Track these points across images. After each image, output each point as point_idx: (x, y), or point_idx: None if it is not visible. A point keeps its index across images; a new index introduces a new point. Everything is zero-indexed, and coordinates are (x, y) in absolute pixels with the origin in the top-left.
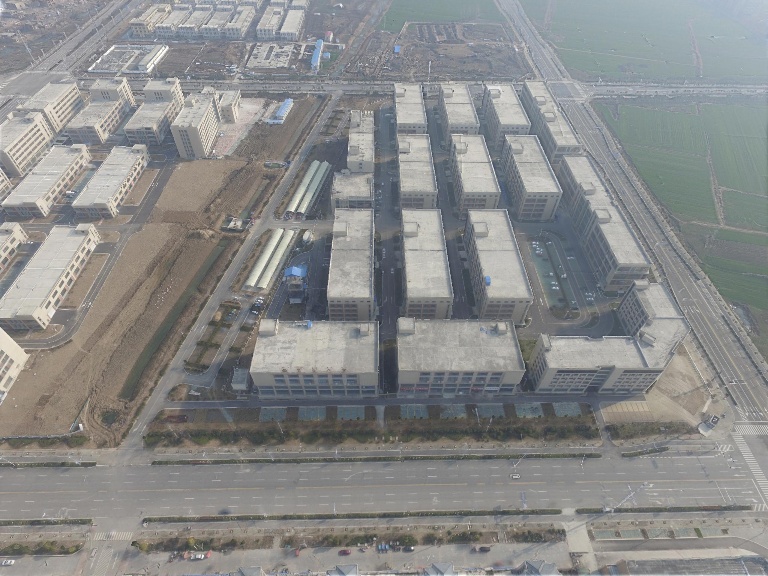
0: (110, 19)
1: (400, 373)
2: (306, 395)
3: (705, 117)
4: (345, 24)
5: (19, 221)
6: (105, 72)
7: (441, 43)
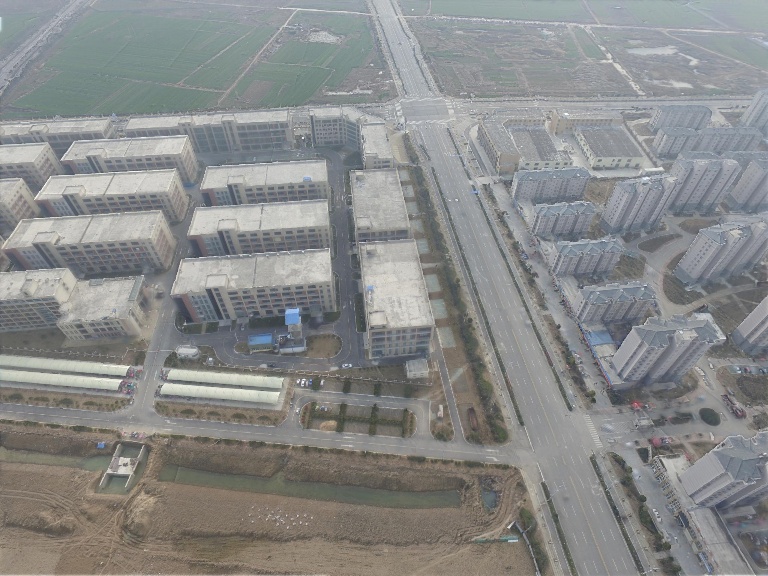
0: None
1: None
2: None
3: (67, 69)
4: None
5: None
6: None
7: None
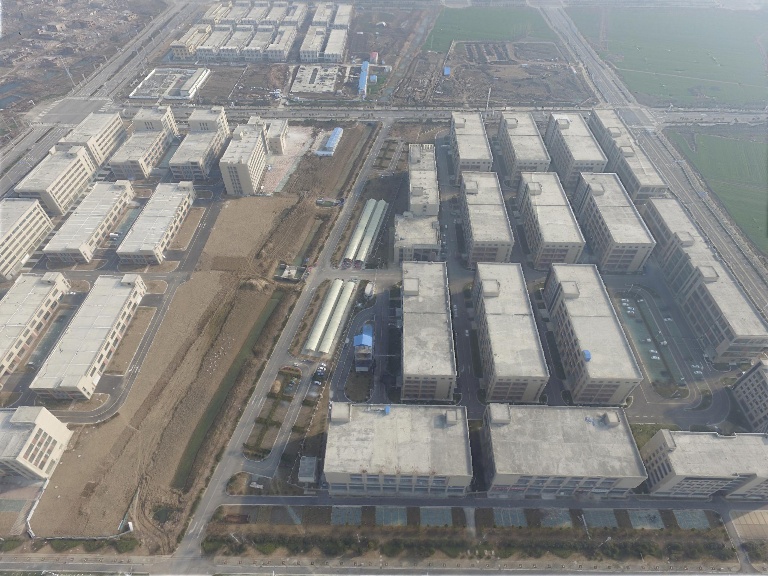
0: (150, 40)
1: (498, 476)
2: (383, 491)
3: None
4: (390, 44)
5: (61, 267)
6: (146, 98)
7: (493, 64)
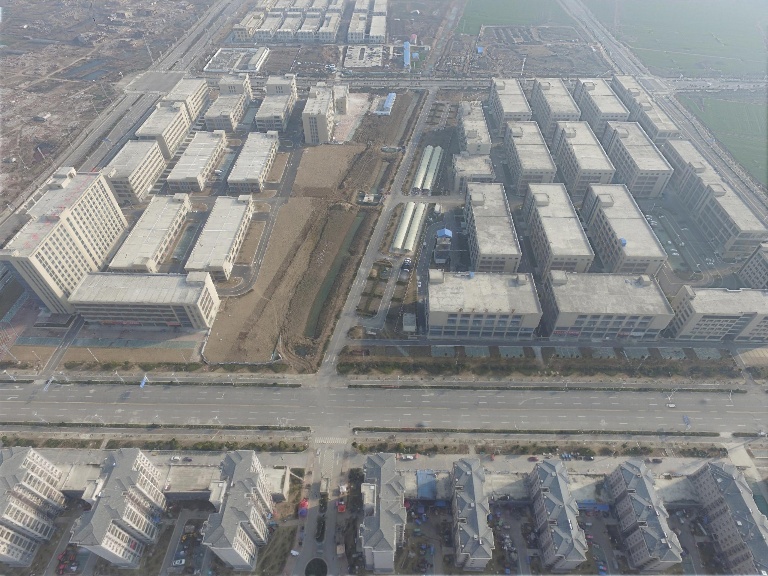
0: (210, 26)
1: (561, 315)
2: (469, 337)
3: None
4: (425, 28)
5: None
6: (218, 71)
7: (520, 44)
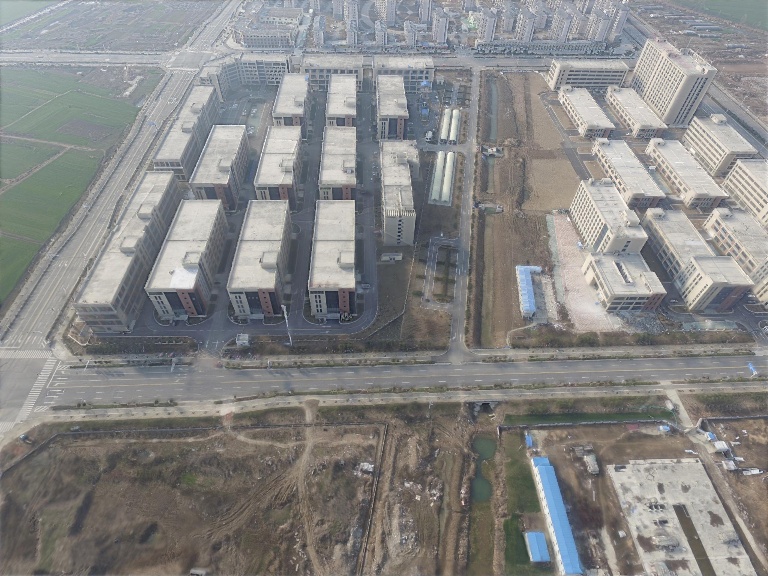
0: None
1: None
2: None
3: None
4: None
5: None
6: None
7: None
